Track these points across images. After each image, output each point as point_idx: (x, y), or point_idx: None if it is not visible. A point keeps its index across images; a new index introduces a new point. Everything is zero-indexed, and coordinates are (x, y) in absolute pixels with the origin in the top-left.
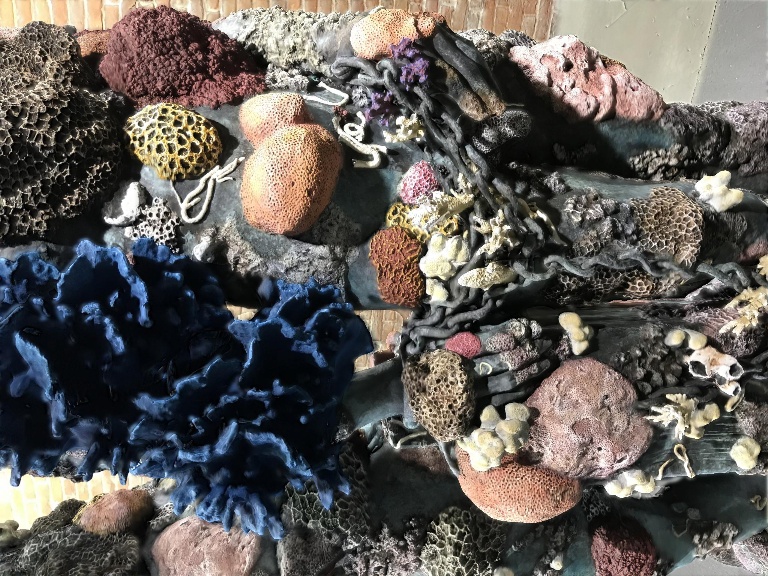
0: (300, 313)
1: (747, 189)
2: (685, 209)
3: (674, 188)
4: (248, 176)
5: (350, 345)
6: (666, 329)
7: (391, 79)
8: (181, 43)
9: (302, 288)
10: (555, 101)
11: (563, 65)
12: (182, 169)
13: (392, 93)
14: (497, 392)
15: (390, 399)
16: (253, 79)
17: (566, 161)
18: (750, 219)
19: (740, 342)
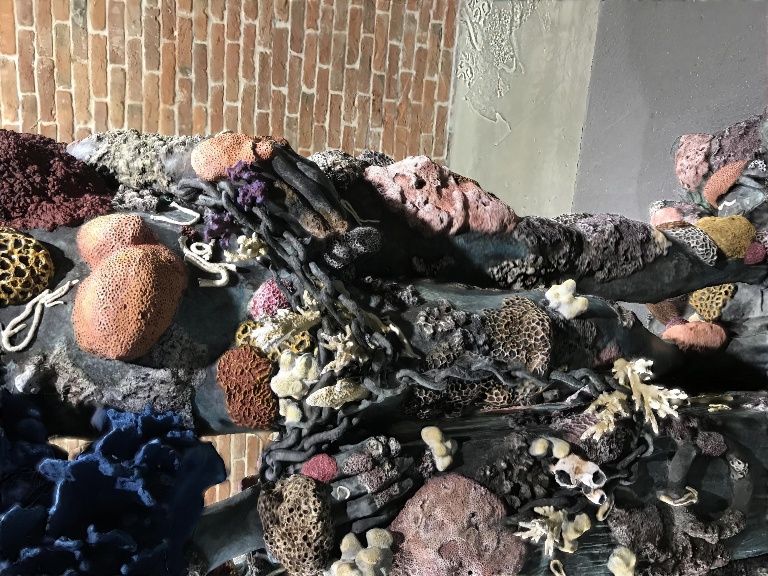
0: (130, 445)
1: (606, 294)
2: (532, 318)
3: (524, 298)
4: (80, 299)
5: (196, 476)
6: (530, 438)
7: (228, 200)
8: (17, 166)
9: (135, 417)
10: (409, 217)
11: (415, 183)
12: (4, 294)
13: (231, 213)
14: (357, 518)
15: (249, 532)
16: (97, 200)
17: (427, 273)
18: (599, 325)
19: (603, 447)
